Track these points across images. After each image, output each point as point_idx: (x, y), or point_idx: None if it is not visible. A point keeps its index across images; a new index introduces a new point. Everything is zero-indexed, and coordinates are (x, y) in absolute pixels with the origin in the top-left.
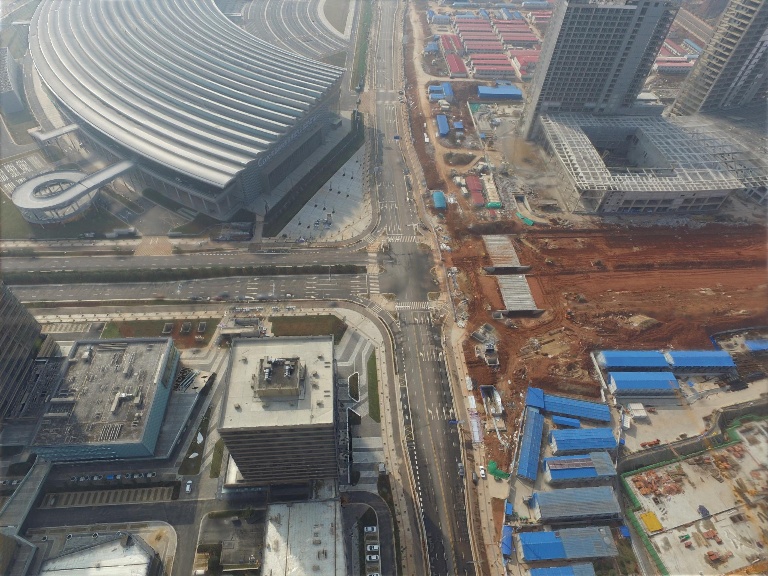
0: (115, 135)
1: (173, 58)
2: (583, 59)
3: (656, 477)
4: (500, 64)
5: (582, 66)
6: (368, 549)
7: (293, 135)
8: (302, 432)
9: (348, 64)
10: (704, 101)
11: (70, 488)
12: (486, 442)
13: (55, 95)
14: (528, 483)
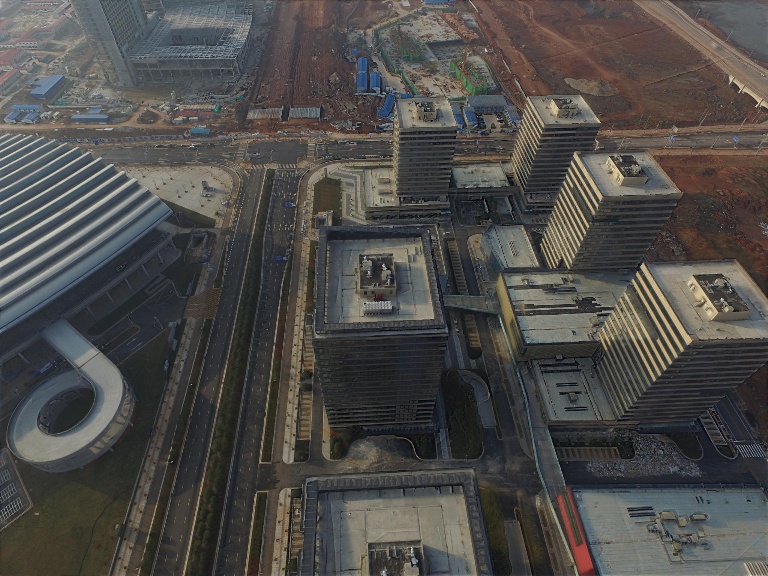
0: None
1: None
2: (113, 1)
3: (422, 91)
4: None
5: (116, 6)
6: None
7: None
8: None
9: None
10: None
11: (455, 289)
12: None
13: None
14: None
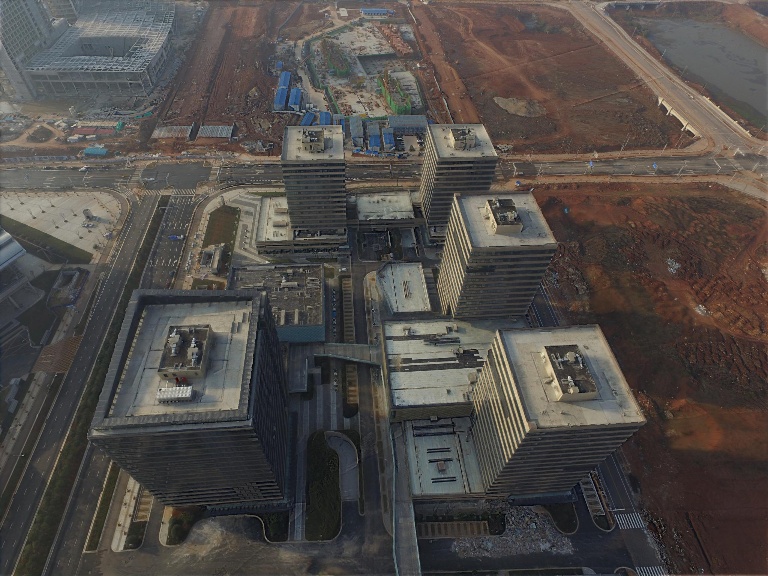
0: None
1: None
2: (3, 7)
3: (344, 109)
4: None
5: (7, 13)
6: None
7: None
8: None
9: None
10: (72, 4)
11: (341, 335)
12: None
13: None
14: (345, 144)
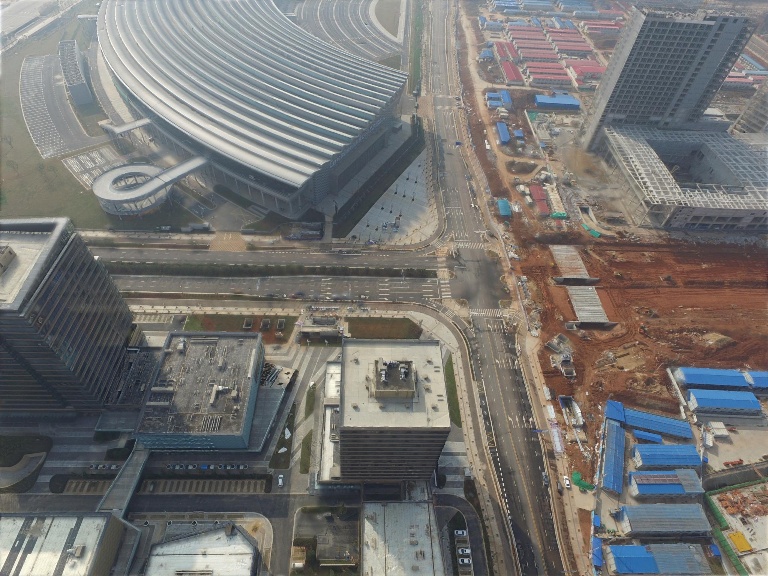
0: (190, 131)
1: (241, 57)
2: (654, 73)
3: (742, 497)
4: (556, 73)
5: (652, 79)
6: (460, 552)
7: (361, 137)
8: (418, 434)
9: (403, 68)
10: None
11: (167, 475)
12: (568, 453)
13: (128, 89)
14: (613, 496)
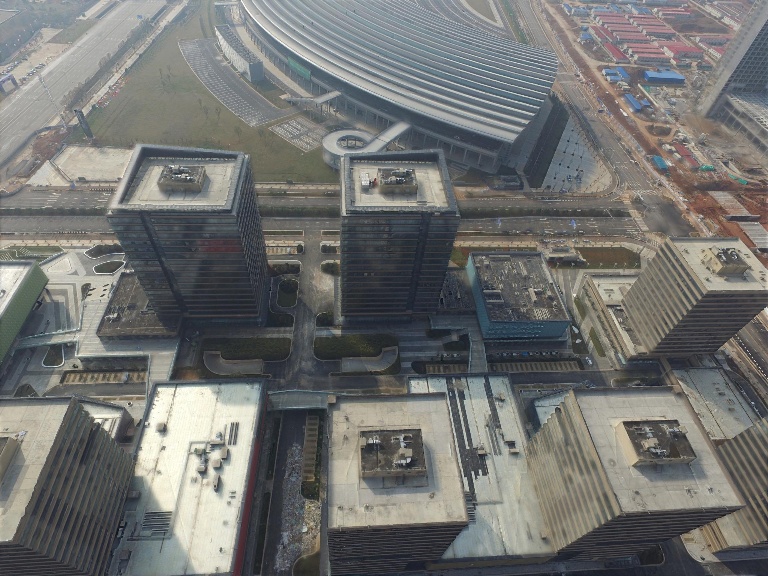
0: (395, 99)
1: None
2: None
3: None
4: (655, 52)
5: None
6: None
7: None
8: (755, 298)
9: None
10: None
11: (500, 360)
12: None
13: (315, 65)
14: None
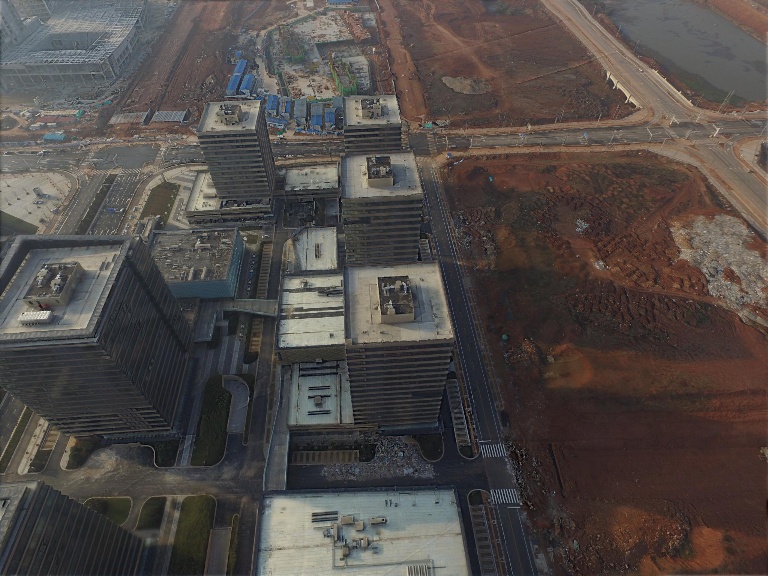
0: None
1: None
2: None
3: None
4: None
5: None
6: None
7: None
8: (261, 116)
9: None
10: (45, 4)
11: (254, 293)
12: None
13: None
14: (289, 125)
